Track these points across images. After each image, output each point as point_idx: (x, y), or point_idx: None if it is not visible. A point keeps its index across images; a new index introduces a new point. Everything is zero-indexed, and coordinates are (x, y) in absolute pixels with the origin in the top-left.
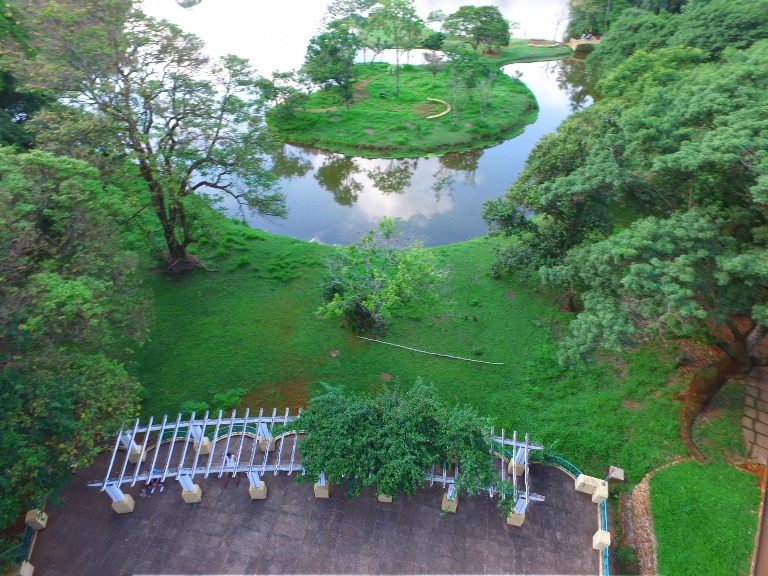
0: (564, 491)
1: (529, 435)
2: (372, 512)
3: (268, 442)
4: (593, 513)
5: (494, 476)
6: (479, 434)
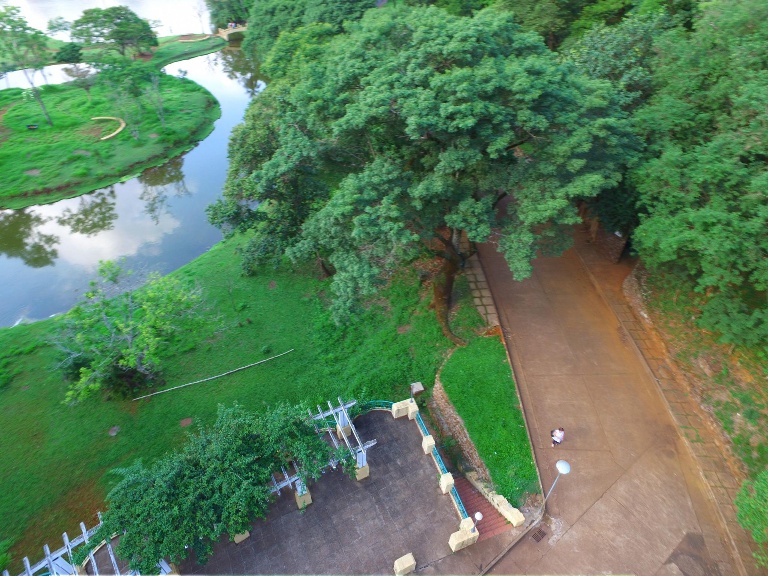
0: (387, 425)
1: (341, 398)
2: (235, 558)
3: (75, 575)
4: (414, 428)
5: (329, 449)
6: (300, 422)
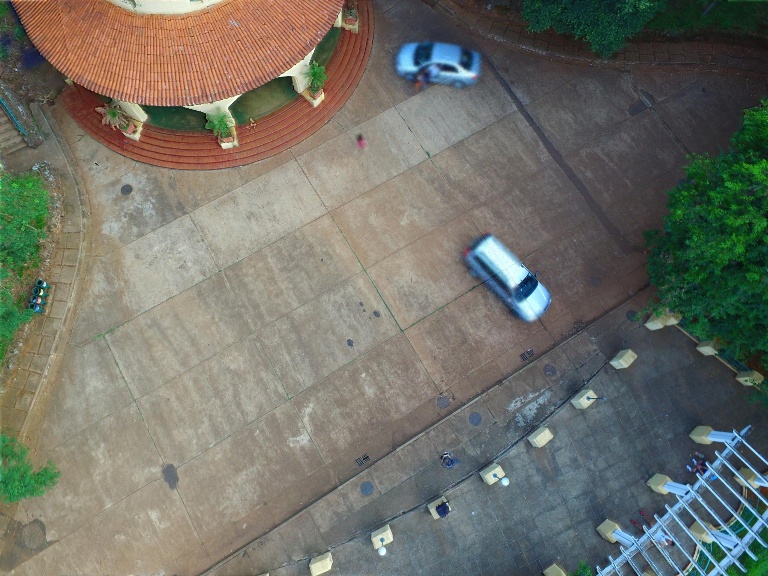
0: None
1: None
2: None
3: None
4: None
5: None
6: None
